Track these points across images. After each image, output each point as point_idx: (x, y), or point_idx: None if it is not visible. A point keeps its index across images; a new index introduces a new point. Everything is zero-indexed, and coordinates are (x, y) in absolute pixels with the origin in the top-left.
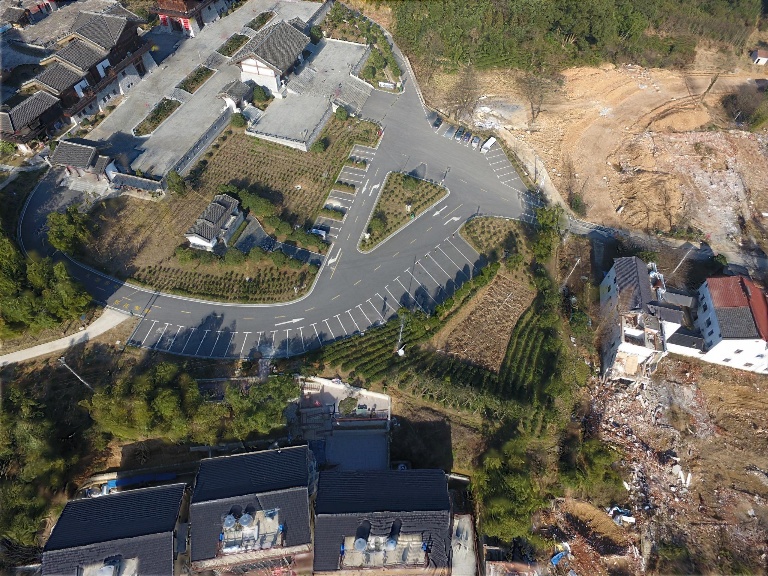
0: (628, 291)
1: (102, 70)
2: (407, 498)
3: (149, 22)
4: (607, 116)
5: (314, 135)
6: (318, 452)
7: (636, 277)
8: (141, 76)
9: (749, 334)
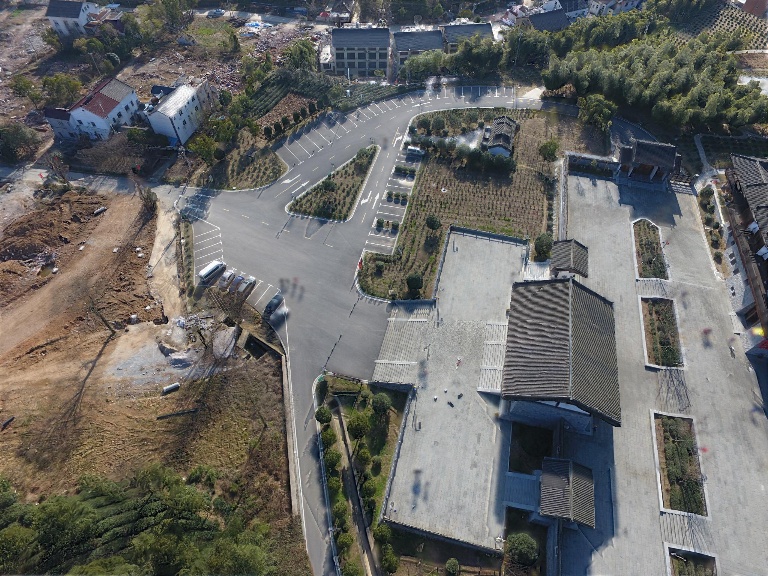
0: (182, 96)
1: None
2: (350, 34)
3: None
4: None
5: None
6: (394, 81)
7: (170, 99)
8: (745, 321)
9: (118, 82)
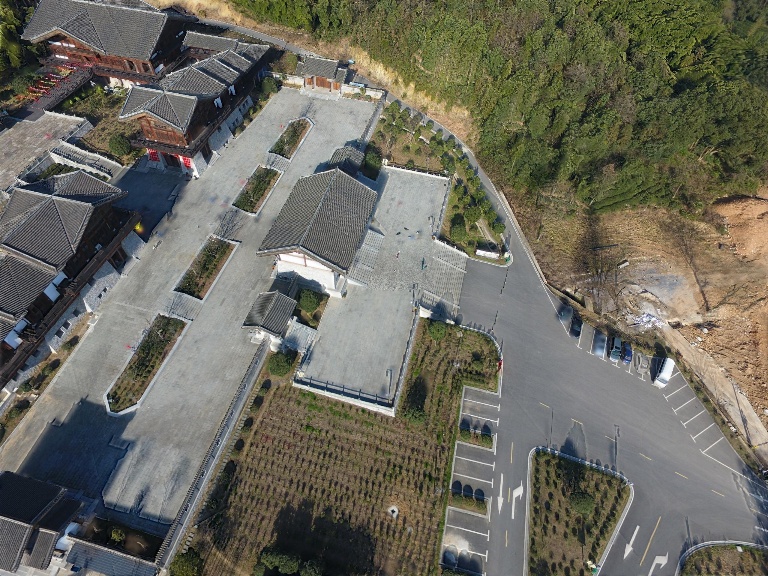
0: None
1: (53, 290)
2: None
3: (131, 150)
4: None
5: (402, 379)
6: None
7: None
8: (120, 267)
9: None
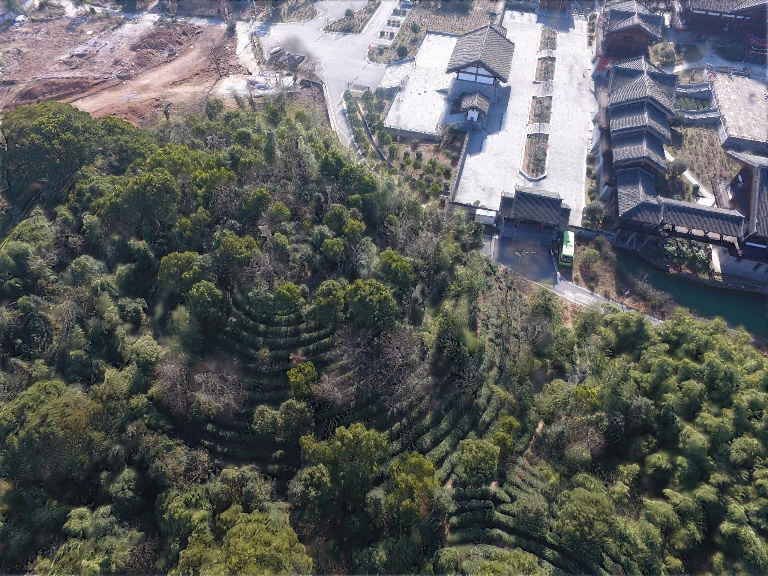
0: None
1: None
2: None
3: None
4: (132, 93)
5: None
6: None
7: None
8: None
9: None
